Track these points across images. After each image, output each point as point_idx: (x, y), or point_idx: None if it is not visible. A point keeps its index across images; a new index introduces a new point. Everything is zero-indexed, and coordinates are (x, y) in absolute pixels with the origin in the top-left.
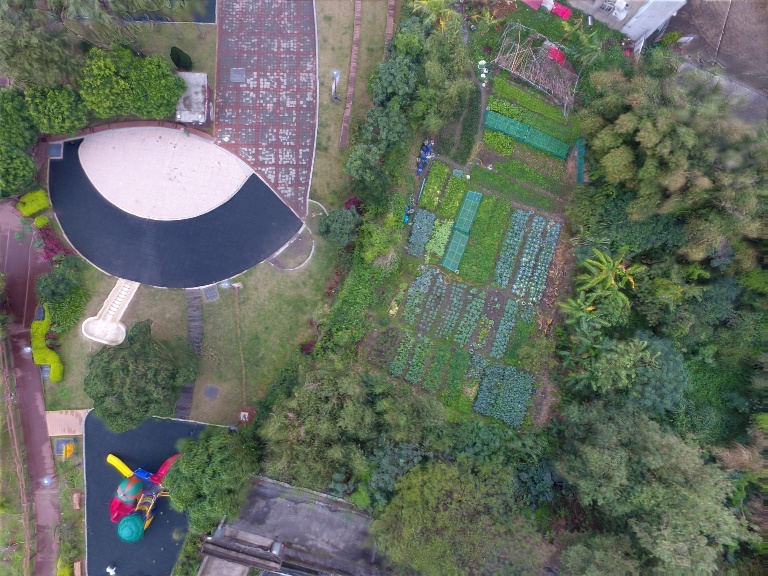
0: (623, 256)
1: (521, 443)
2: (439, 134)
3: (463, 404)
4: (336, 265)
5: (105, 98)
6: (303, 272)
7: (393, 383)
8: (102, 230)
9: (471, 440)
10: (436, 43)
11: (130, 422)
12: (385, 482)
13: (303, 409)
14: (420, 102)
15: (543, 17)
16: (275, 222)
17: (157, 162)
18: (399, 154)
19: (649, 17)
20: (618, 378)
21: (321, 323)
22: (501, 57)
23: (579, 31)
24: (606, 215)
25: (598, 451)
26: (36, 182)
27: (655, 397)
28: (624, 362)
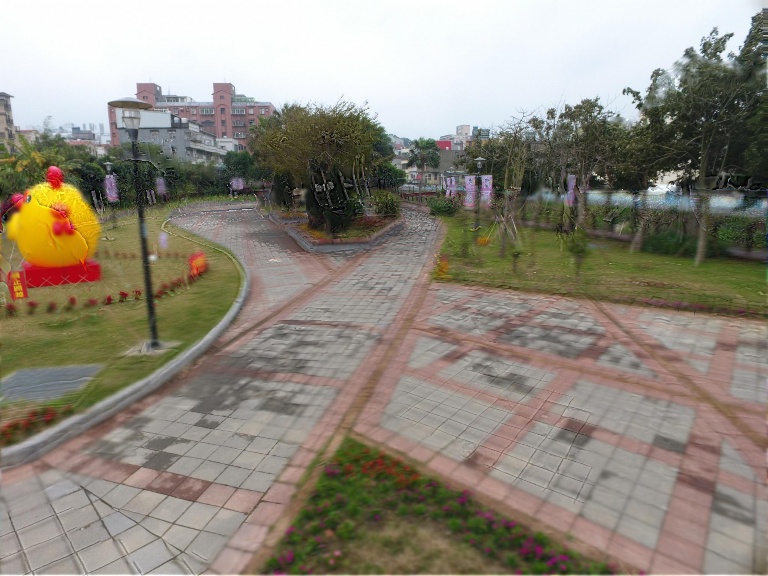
0: None
1: None
2: None
3: None
4: None
5: None
6: None
7: None
8: None
9: None
10: None
11: None
12: None
13: None
14: None
15: None
16: None
17: None
18: None
19: None
20: None
21: None
22: None
23: None
24: None
25: None
26: None
27: None
28: None
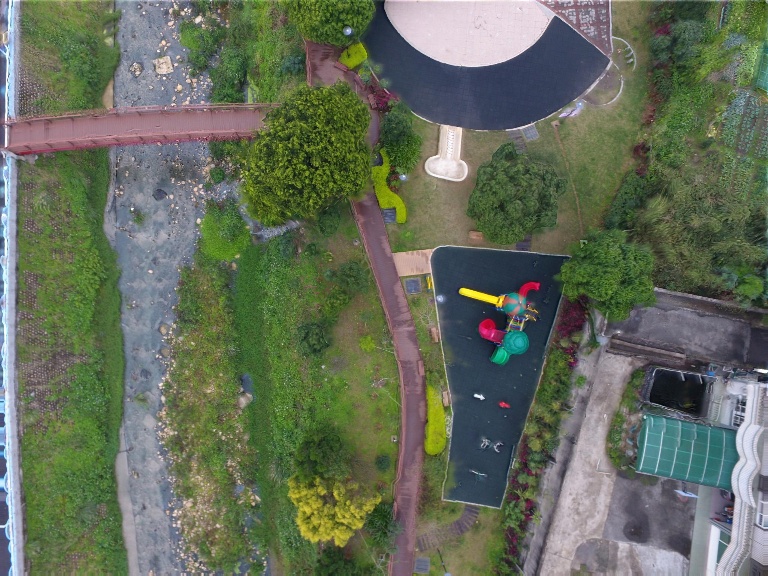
0: None
1: None
2: None
3: None
4: (653, 94)
5: None
6: (617, 106)
7: None
8: (418, 80)
9: None
10: None
11: (522, 232)
12: None
13: (678, 212)
14: None
15: None
16: (583, 60)
17: (461, 12)
18: None
19: None
20: None
21: (655, 145)
22: None
23: None
24: None
25: None
26: None
27: None
28: None
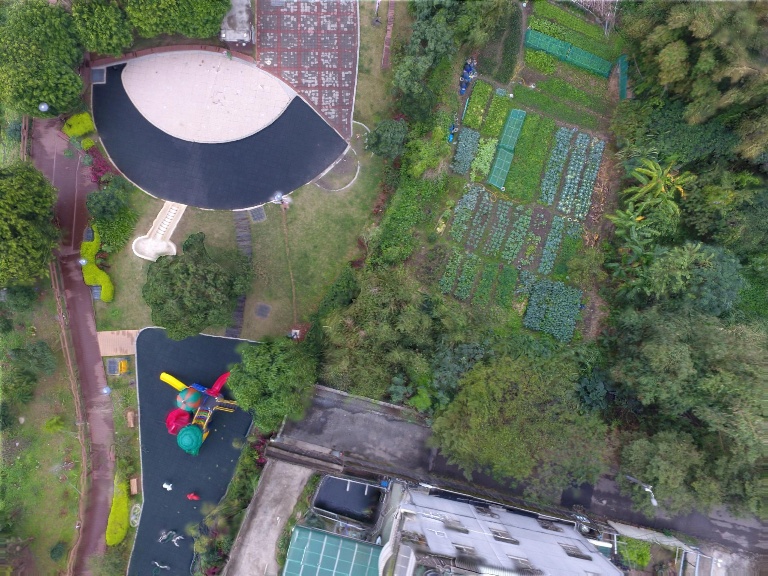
0: (670, 167)
1: (574, 351)
2: (481, 54)
3: (512, 319)
4: (383, 183)
5: (152, 14)
6: (349, 192)
7: (442, 299)
8: (147, 153)
9: (523, 351)
10: None
11: (189, 329)
12: (447, 379)
13: (360, 316)
14: (466, 16)
15: None
16: (320, 143)
17: (200, 86)
18: (443, 72)
19: None
20: (672, 281)
21: (371, 238)
22: None
23: None
24: (653, 126)
25: (657, 348)
26: (81, 105)
27: (711, 295)
28: (679, 263)
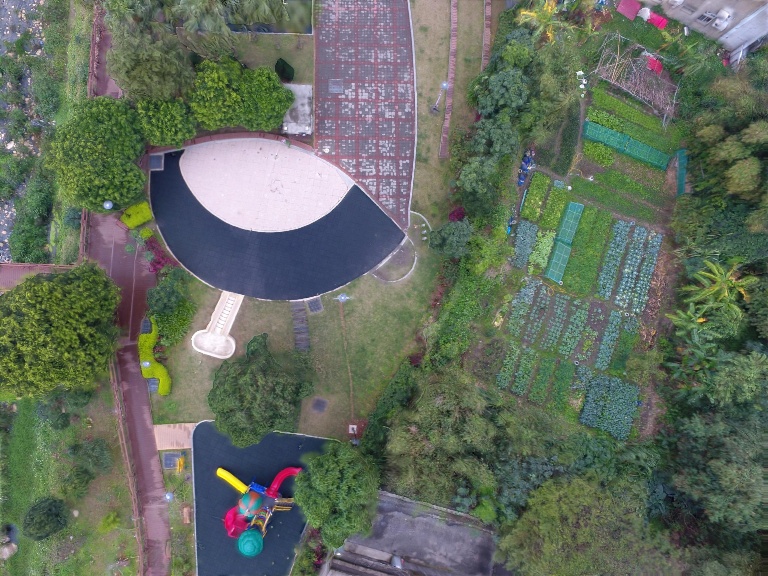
0: None
1: (635, 455)
2: (539, 145)
3: (569, 416)
4: (441, 277)
5: (217, 111)
6: (406, 284)
7: (500, 395)
8: (205, 242)
9: (583, 452)
10: (550, 55)
11: (255, 437)
12: (517, 497)
13: (425, 423)
14: (529, 114)
15: (639, 28)
16: (377, 234)
17: (258, 174)
18: (502, 165)
19: (751, 28)
20: (737, 390)
21: (430, 335)
22: (601, 68)
23: (679, 42)
24: (714, 227)
25: (725, 464)
26: None
27: None
28: (745, 375)
